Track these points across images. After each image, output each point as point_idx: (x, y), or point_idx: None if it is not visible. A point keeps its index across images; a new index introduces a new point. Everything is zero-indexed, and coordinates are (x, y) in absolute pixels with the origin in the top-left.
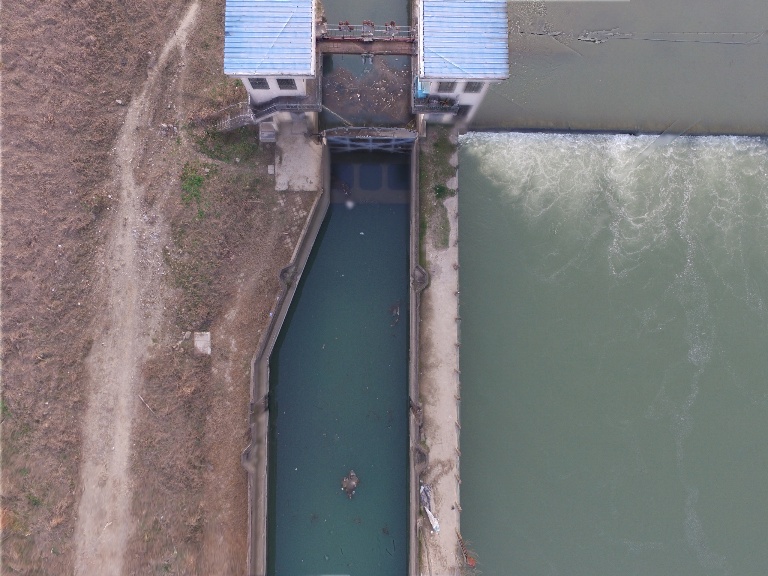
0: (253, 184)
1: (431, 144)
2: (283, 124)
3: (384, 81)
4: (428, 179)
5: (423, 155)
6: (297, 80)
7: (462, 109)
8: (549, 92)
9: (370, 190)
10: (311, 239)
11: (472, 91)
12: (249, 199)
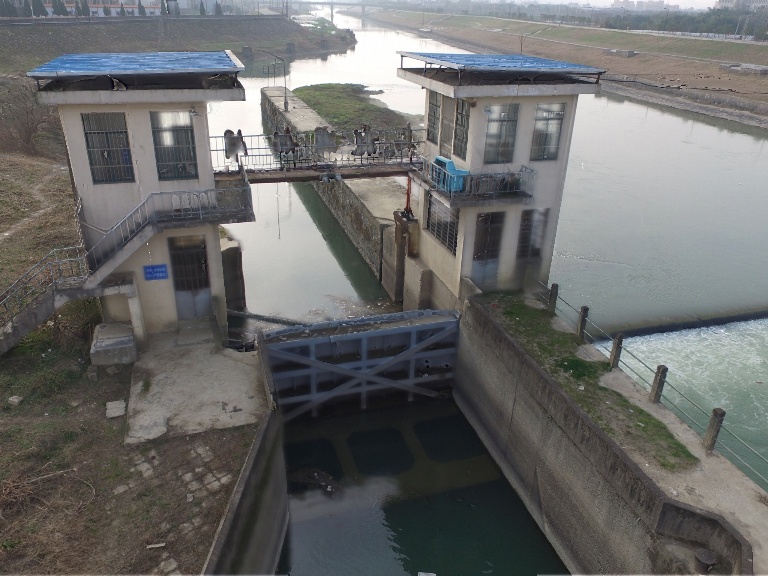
0: (52, 444)
1: (497, 314)
2: (155, 337)
3: (352, 316)
4: (531, 355)
5: None
6: (200, 138)
7: (529, 231)
8: (624, 296)
9: (389, 475)
10: None
11: (543, 156)
12: (29, 476)
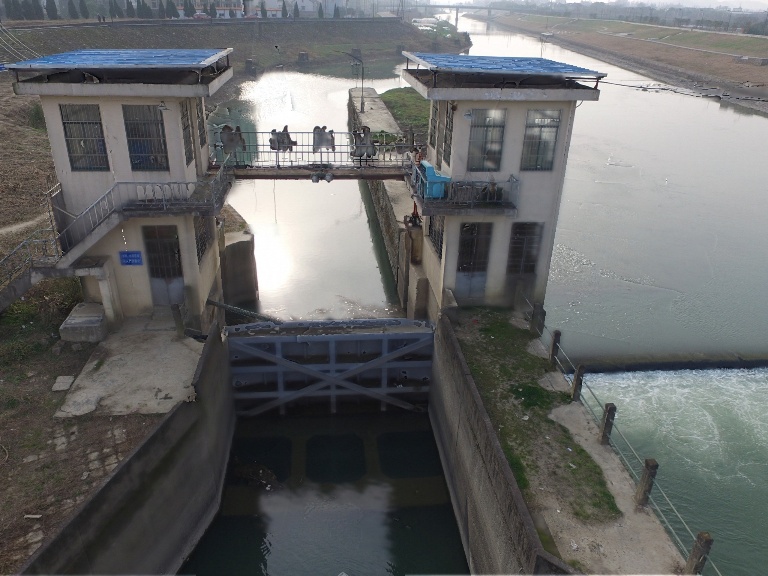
0: None
1: (473, 330)
2: None
3: None
4: (487, 377)
5: (460, 343)
6: (171, 132)
7: (522, 245)
8: (661, 325)
9: (335, 483)
10: (128, 569)
11: (536, 166)
12: None
